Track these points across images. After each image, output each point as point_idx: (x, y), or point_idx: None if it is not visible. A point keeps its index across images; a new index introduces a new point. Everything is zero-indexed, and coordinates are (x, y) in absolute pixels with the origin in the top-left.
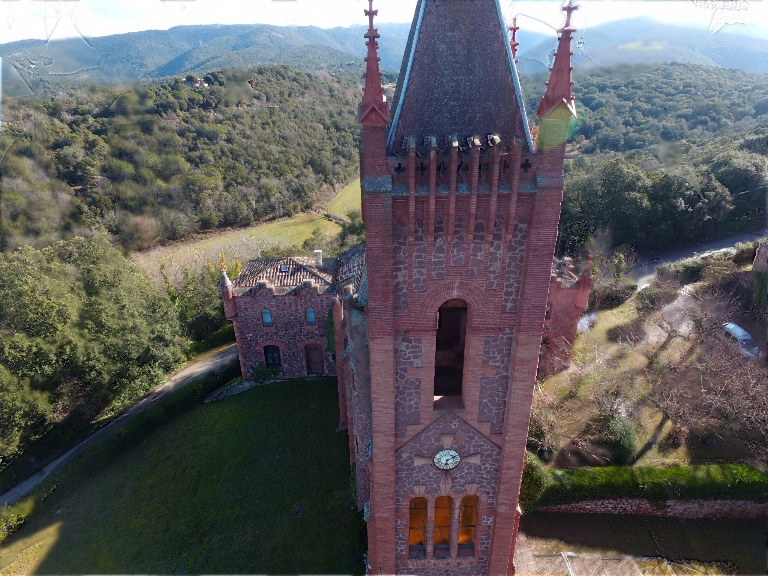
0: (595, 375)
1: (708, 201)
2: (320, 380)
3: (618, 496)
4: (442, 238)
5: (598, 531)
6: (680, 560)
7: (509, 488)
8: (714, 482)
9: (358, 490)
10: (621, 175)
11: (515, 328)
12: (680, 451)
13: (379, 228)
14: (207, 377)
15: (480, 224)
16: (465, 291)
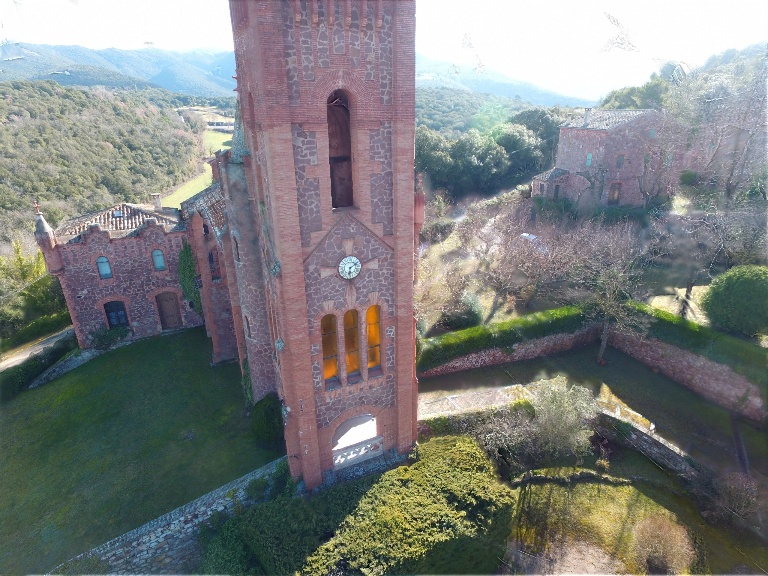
0: (440, 283)
1: (493, 157)
2: (179, 333)
3: (478, 350)
4: (324, 24)
5: (469, 379)
6: (530, 383)
7: (405, 289)
8: (541, 321)
9: (254, 382)
10: (426, 139)
11: (392, 122)
12: (513, 315)
13: (268, 1)
14: (27, 362)
15: (354, 12)
16: (348, 81)
